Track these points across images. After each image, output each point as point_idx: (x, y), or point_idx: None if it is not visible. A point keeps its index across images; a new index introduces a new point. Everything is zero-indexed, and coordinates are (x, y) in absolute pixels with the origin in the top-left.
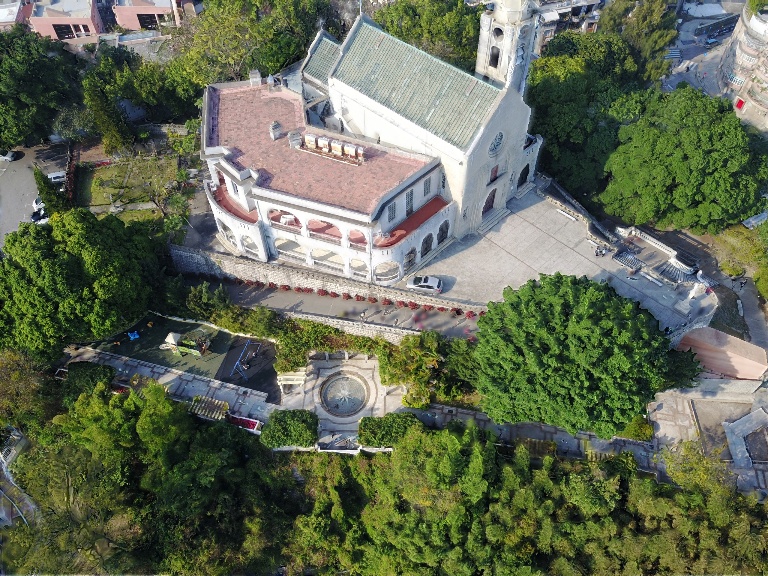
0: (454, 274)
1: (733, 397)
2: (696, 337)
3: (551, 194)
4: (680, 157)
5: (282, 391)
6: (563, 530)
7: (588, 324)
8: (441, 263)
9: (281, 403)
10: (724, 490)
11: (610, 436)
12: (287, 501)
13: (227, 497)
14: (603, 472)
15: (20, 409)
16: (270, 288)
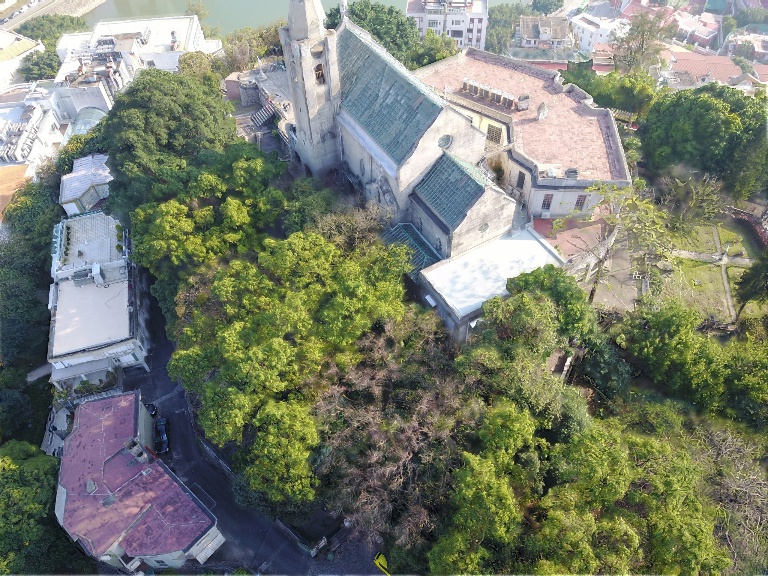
0: None
1: None
2: None
3: None
4: None
5: None
6: None
7: None
8: None
9: None
10: None
11: None
12: None
13: None
14: None
15: None
16: None
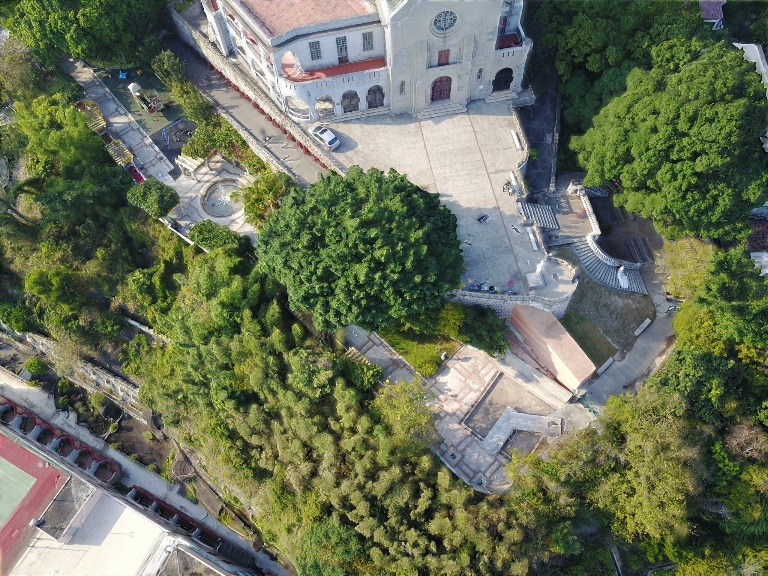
0: (360, 141)
1: (543, 394)
2: (525, 314)
3: (544, 118)
4: (649, 127)
5: (182, 170)
6: (271, 385)
7: (354, 222)
8: (358, 126)
9: (177, 179)
10: (401, 436)
11: (318, 328)
12: (142, 254)
13: (91, 222)
14: (328, 363)
15: (8, 87)
16: (227, 83)
